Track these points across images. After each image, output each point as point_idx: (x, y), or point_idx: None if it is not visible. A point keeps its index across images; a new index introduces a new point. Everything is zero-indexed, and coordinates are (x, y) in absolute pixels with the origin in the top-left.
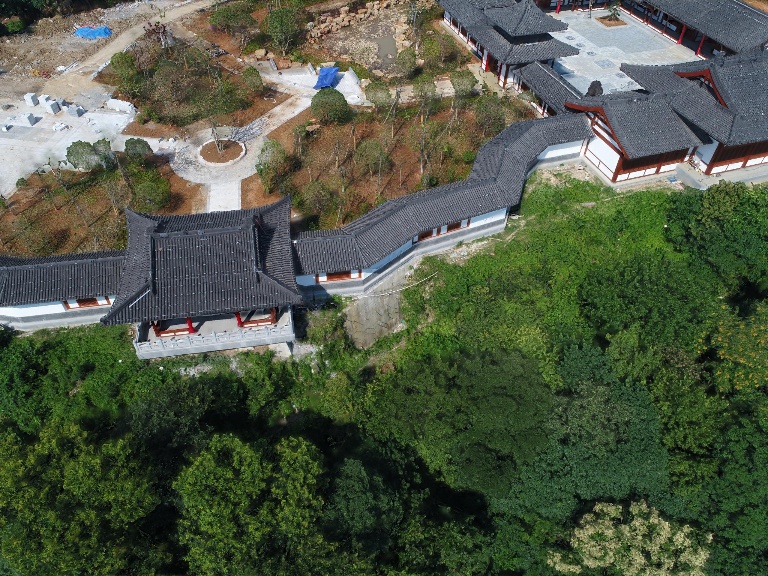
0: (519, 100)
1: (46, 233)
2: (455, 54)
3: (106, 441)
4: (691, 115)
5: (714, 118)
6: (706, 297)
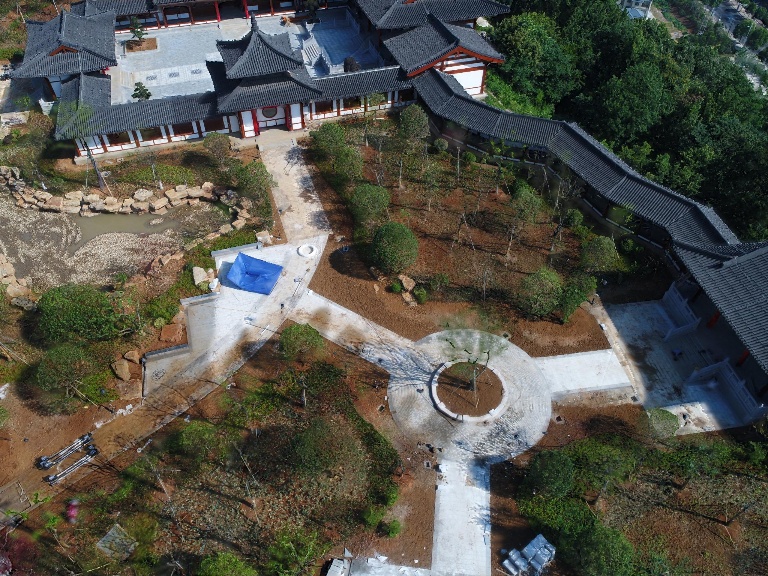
0: (326, 123)
1: None
2: (194, 156)
3: None
4: (461, 16)
5: (471, 7)
6: None
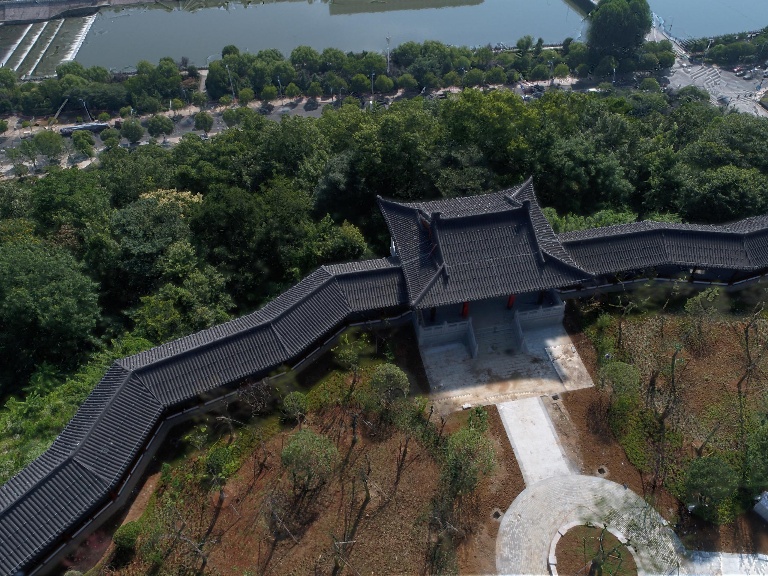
0: None
1: (677, 286)
2: None
3: (501, 181)
4: None
5: None
6: (3, 247)
